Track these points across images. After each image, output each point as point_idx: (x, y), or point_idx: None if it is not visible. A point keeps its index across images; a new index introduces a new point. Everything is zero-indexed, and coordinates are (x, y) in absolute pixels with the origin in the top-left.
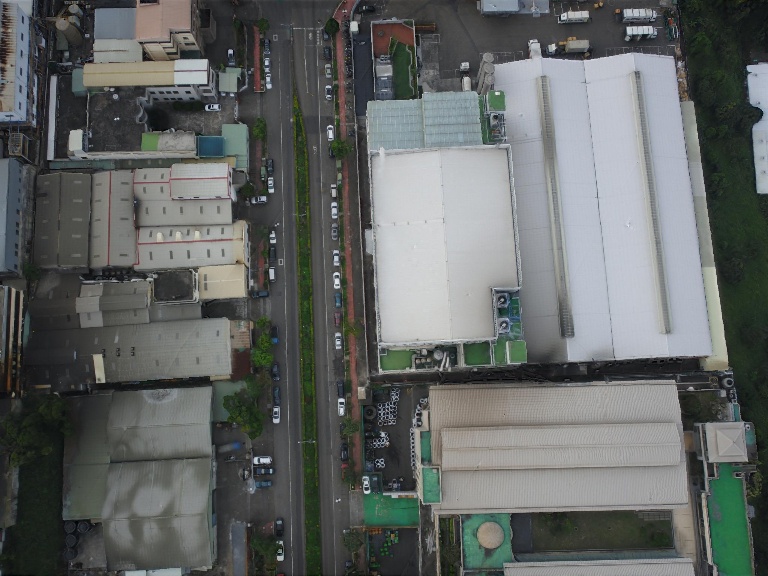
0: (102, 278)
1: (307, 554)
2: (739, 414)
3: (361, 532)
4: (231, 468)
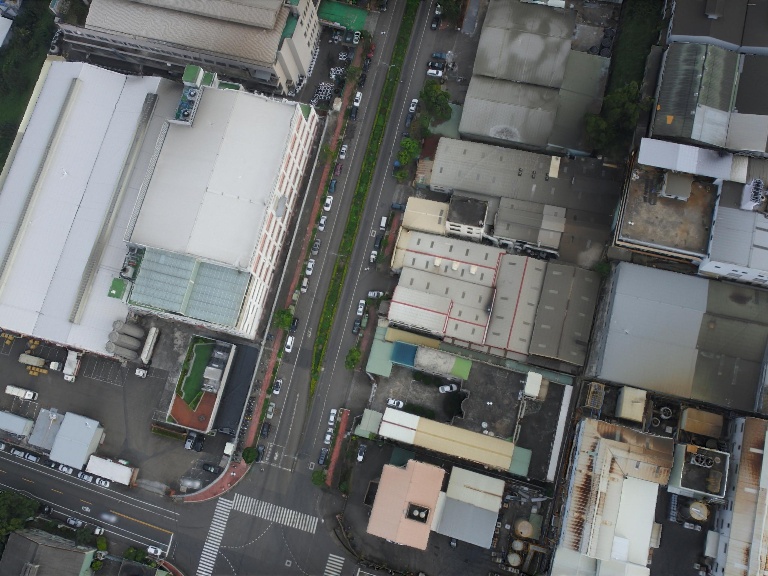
0: (540, 254)
1: (419, 1)
2: (53, 0)
3: (372, 6)
4: (463, 74)
